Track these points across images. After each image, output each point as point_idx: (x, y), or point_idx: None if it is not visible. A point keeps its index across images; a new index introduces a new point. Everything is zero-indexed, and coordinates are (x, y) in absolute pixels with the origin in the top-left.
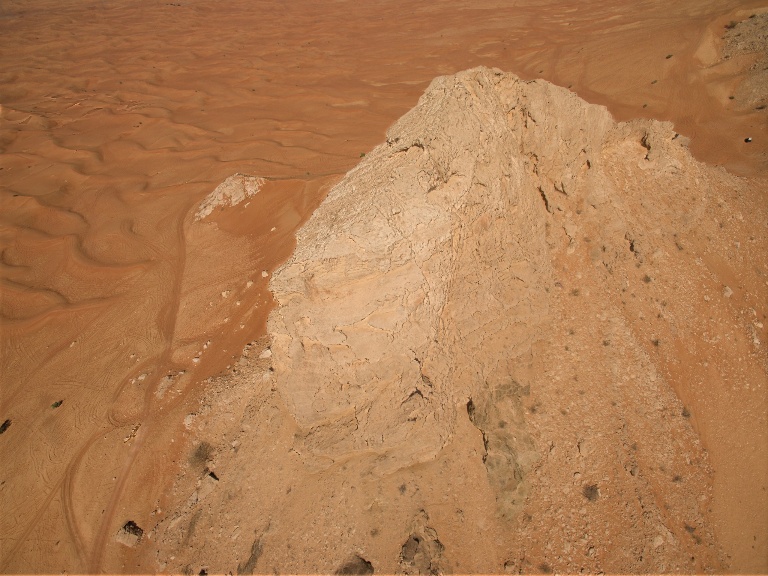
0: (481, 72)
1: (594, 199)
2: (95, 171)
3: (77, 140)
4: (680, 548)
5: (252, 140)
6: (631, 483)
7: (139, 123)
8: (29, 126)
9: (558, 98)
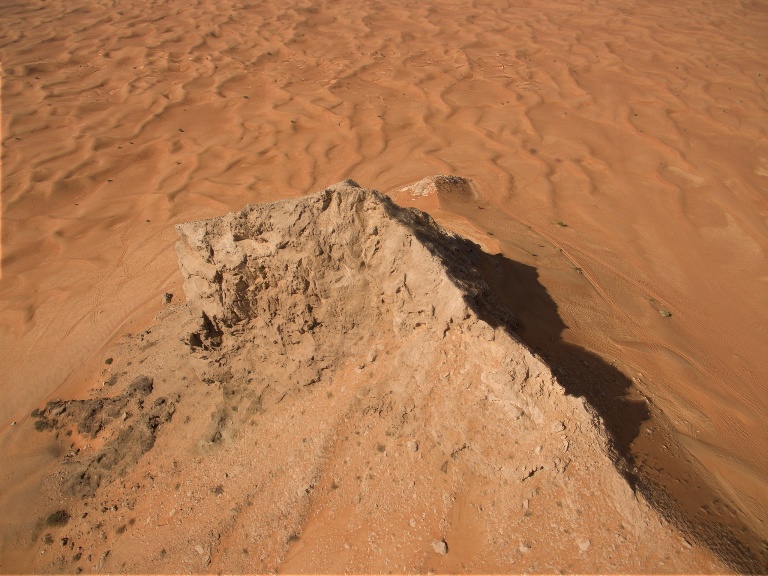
0: (350, 192)
1: (401, 354)
2: (435, 123)
3: (457, 95)
4: (204, 571)
5: (541, 158)
6: (228, 513)
7: (507, 101)
8: (455, 71)
9: (418, 253)
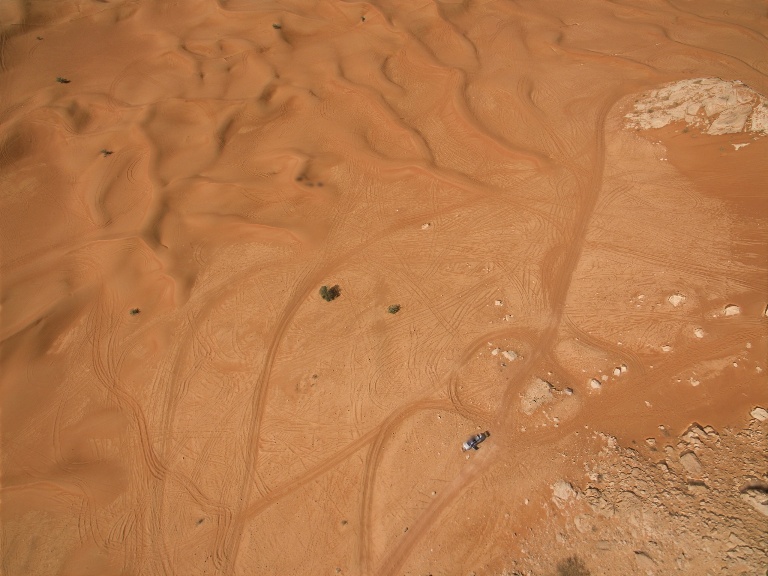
0: None
1: None
2: None
3: None
4: None
5: (728, 22)
6: None
7: None
8: None
9: None
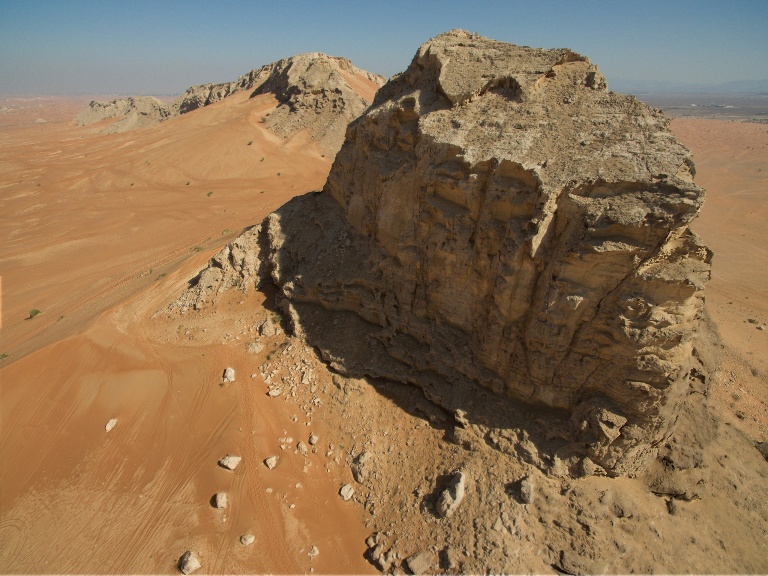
0: None
1: None
2: None
3: None
4: None
5: None
6: None
7: None
8: None
9: None
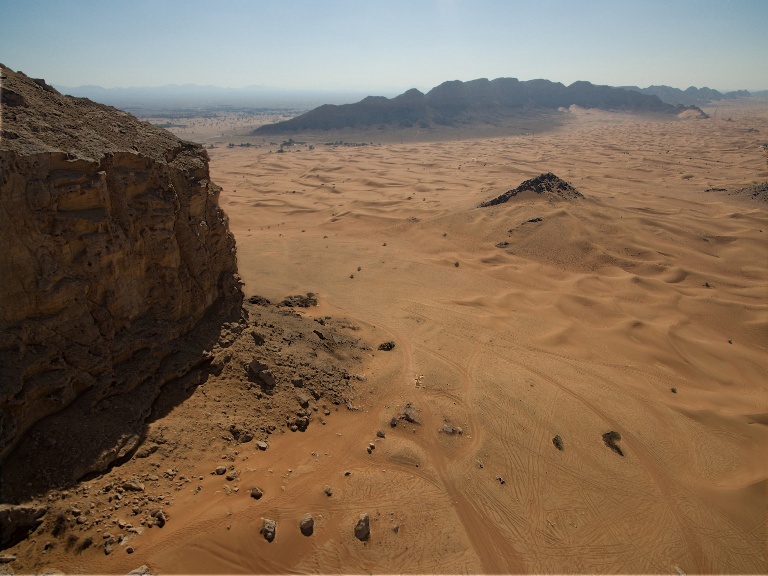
0: None
1: None
2: None
3: None
4: None
5: None
6: None
7: None
8: None
9: None
